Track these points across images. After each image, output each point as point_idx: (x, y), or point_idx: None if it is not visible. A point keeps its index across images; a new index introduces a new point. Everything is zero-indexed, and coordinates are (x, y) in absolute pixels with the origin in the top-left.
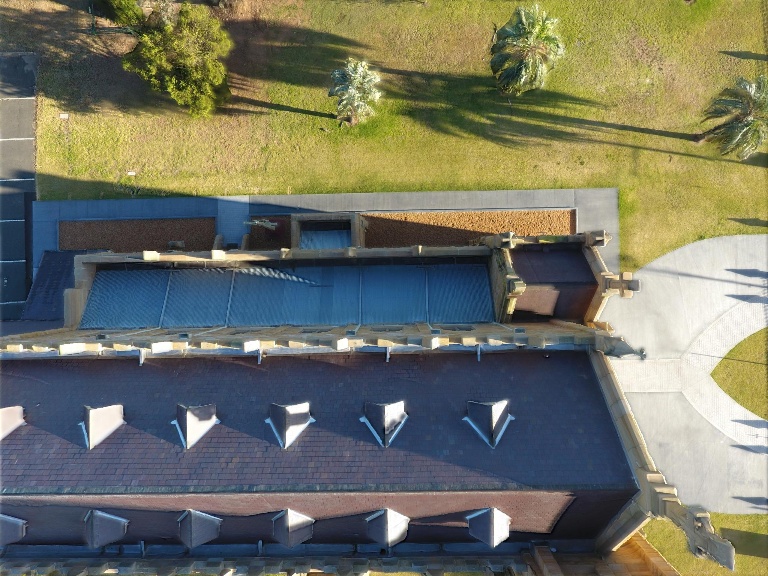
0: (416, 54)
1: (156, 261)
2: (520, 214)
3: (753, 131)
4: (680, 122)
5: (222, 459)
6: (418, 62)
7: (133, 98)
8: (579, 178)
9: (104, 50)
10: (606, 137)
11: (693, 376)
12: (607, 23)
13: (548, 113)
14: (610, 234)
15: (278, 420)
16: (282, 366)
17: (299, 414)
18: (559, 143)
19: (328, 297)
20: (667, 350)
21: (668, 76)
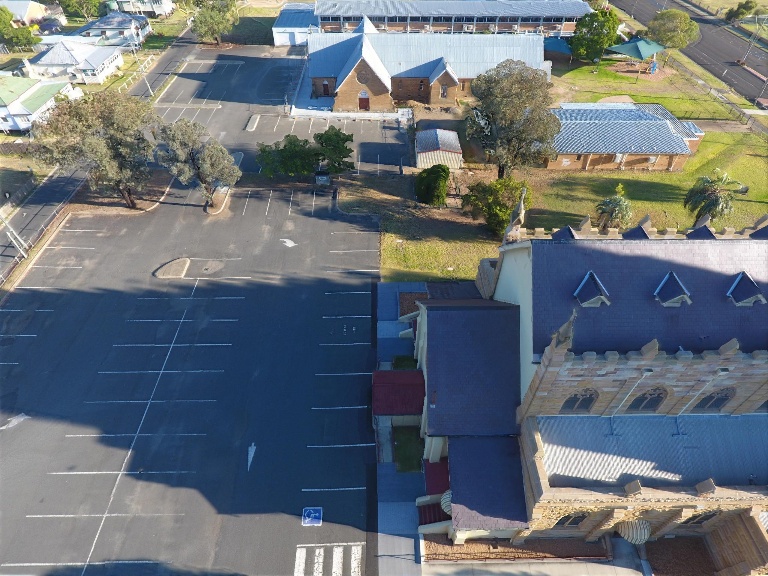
0: None
1: None
2: None
3: None
4: None
5: None
6: None
7: (445, 235)
8: None
9: (422, 215)
10: None
11: None
12: None
13: None
14: None
15: (766, 235)
16: None
17: None
18: None
19: None
20: None
21: None
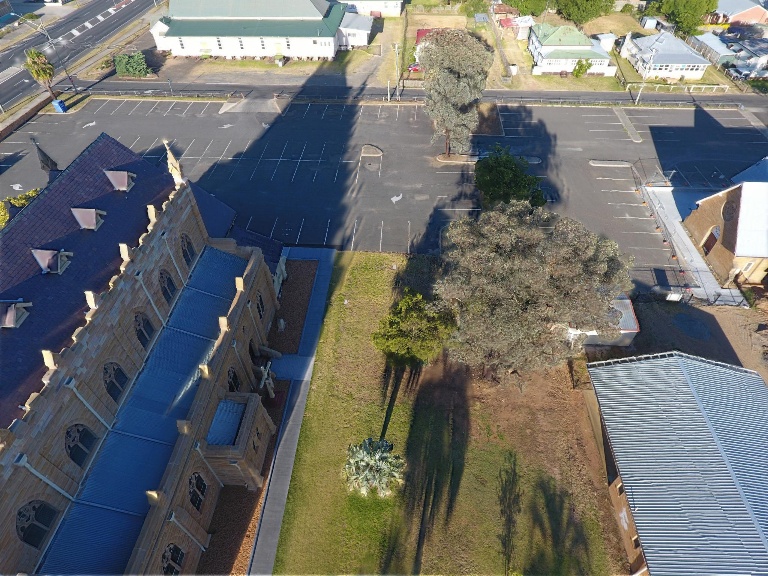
0: (442, 570)
1: (237, 288)
2: None
3: None
4: None
5: (6, 264)
6: (433, 572)
7: None
8: None
9: None
10: None
11: None
12: None
13: None
14: None
15: None
16: (71, 326)
17: (6, 316)
18: None
19: (157, 408)
20: None
21: None
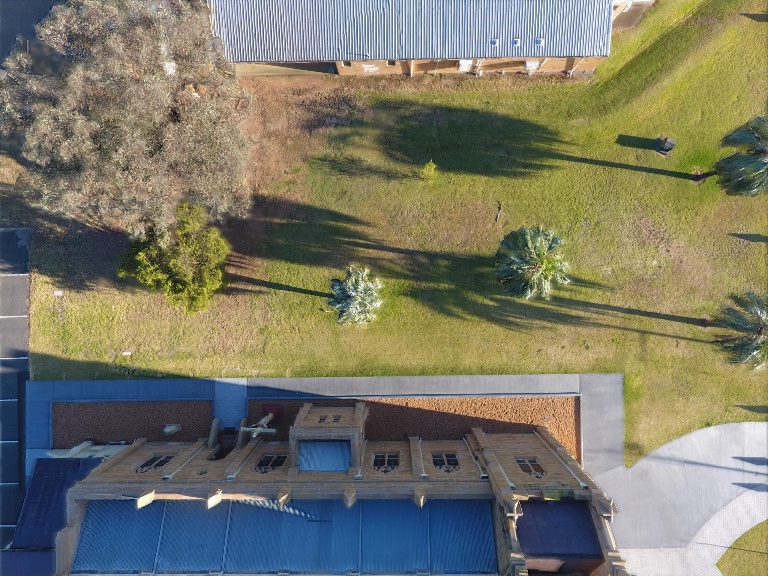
0: (418, 232)
1: (151, 501)
2: (523, 400)
3: (763, 352)
4: (687, 306)
5: None
6: (420, 240)
7: None
8: (584, 363)
9: (99, 225)
10: (612, 321)
11: (698, 566)
12: (614, 203)
13: (553, 295)
14: (615, 420)
15: None
16: None
17: None
18: (564, 326)
19: (327, 535)
20: (672, 539)
21: (676, 258)
